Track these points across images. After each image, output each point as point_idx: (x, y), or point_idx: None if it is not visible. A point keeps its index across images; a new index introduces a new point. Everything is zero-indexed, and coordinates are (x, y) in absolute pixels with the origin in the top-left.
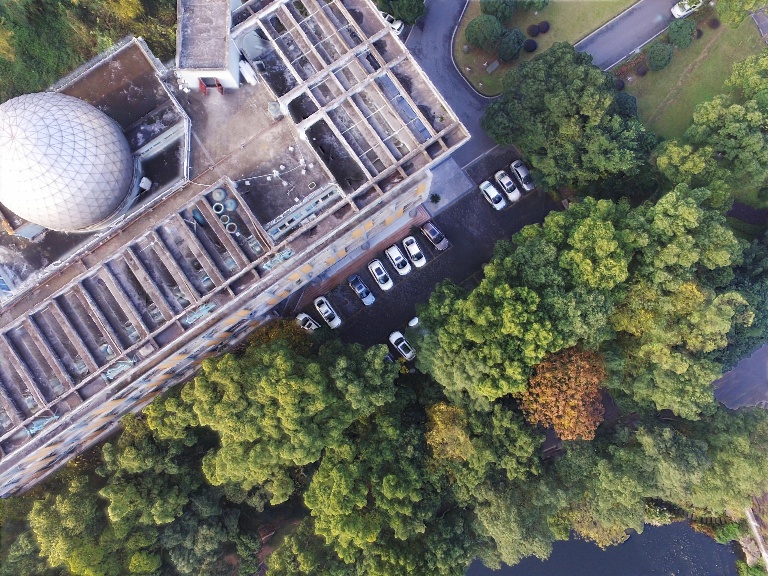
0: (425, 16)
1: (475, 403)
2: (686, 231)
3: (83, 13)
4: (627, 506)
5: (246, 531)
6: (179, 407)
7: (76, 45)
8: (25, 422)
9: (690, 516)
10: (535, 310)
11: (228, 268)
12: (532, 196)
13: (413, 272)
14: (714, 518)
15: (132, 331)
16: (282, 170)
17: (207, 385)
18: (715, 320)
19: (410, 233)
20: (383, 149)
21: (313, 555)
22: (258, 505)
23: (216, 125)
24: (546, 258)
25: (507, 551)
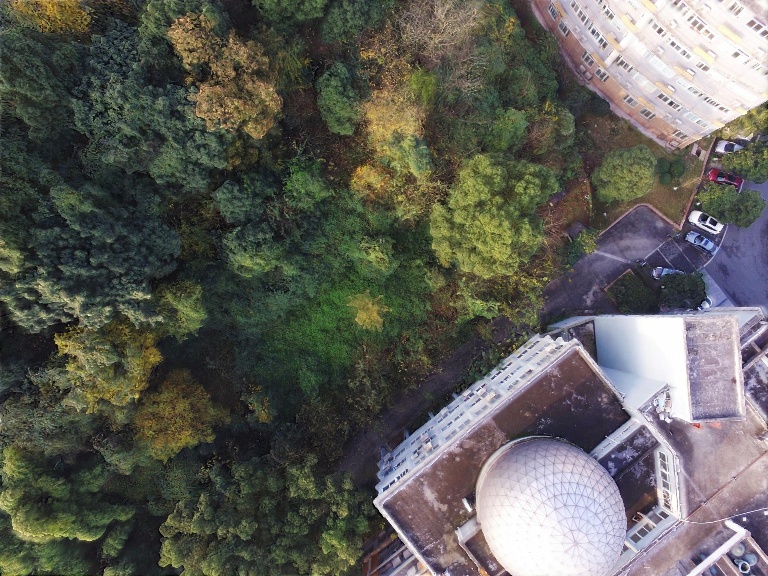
0: None
1: None
2: None
3: (448, 272)
4: None
5: None
6: None
7: (420, 292)
8: None
9: None
10: None
11: None
12: None
13: None
14: None
15: None
16: None
17: None
18: None
19: None
20: None
21: None
22: None
23: (703, 456)
24: None
25: None
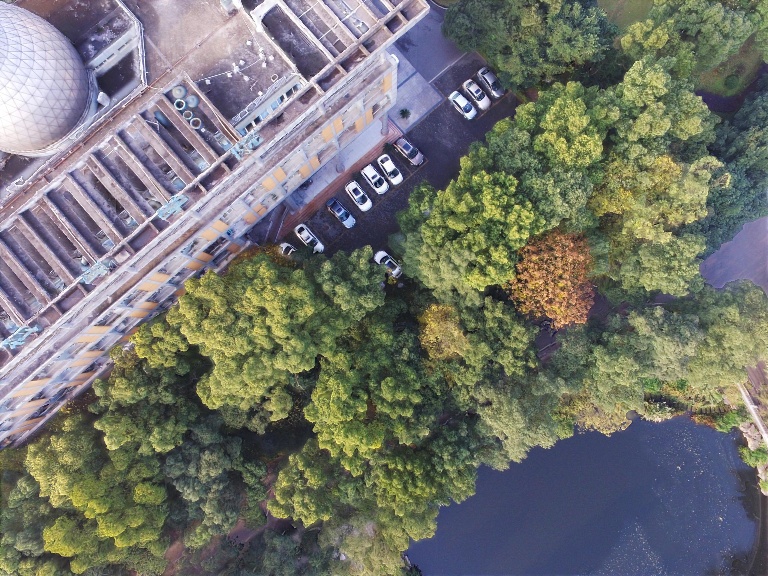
0: None
1: (465, 299)
2: (656, 99)
3: None
4: (626, 385)
5: (250, 460)
6: (166, 332)
7: None
8: (4, 342)
9: (690, 408)
10: (515, 194)
11: (197, 166)
12: (502, 103)
13: (391, 191)
14: (713, 408)
15: (105, 239)
16: (242, 65)
17: (191, 302)
18: (693, 185)
19: (384, 151)
20: (342, 29)
21: (319, 469)
22: (259, 428)
23: (169, 27)
24: (520, 144)
25: (512, 444)
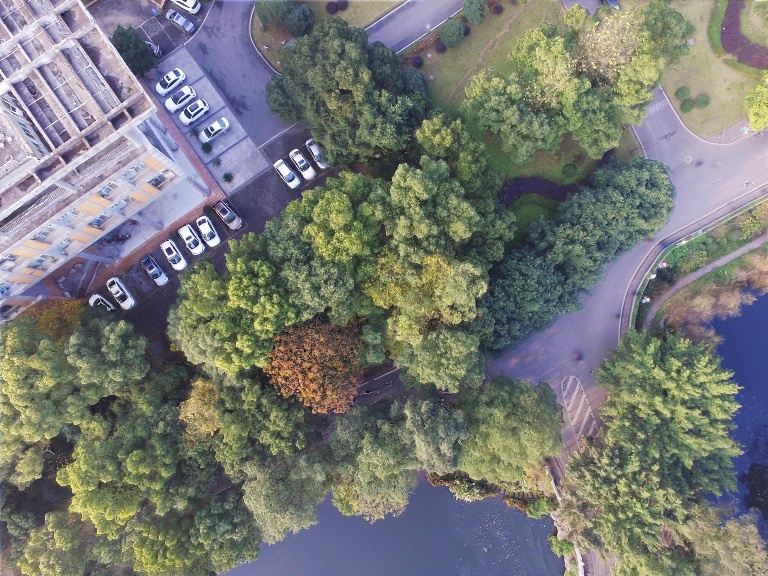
0: None
1: None
2: (419, 203)
3: None
4: None
5: (20, 511)
6: None
7: None
8: None
9: (503, 491)
10: (270, 283)
11: None
12: (328, 174)
13: (208, 252)
14: (526, 493)
15: None
16: None
17: None
18: (448, 291)
19: (204, 213)
20: (69, 120)
21: (69, 532)
22: (19, 484)
23: None
24: (290, 232)
25: (267, 525)
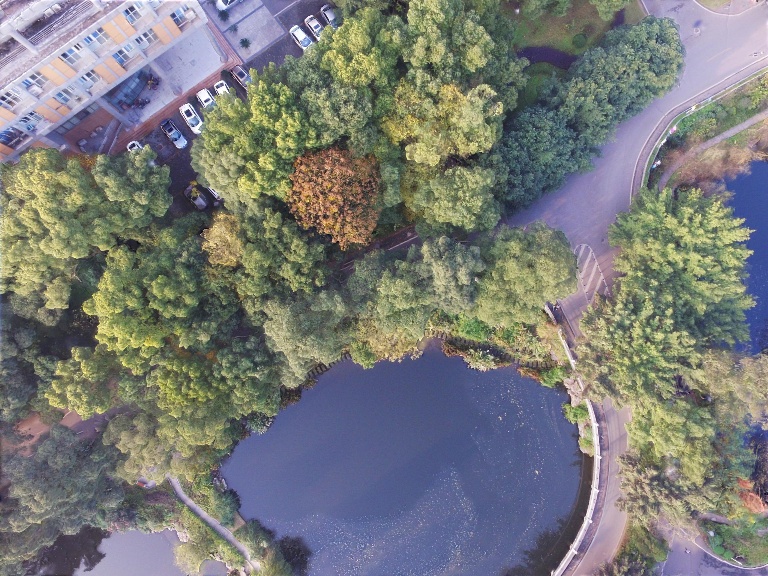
0: None
1: None
2: (435, 25)
3: None
4: (401, 308)
5: (46, 355)
6: None
7: None
8: None
9: (516, 361)
10: None
11: None
12: None
13: None
14: (540, 362)
15: None
16: None
17: None
18: (465, 111)
19: (221, 78)
20: None
21: (95, 362)
22: (46, 319)
23: None
24: (309, 62)
25: (288, 357)
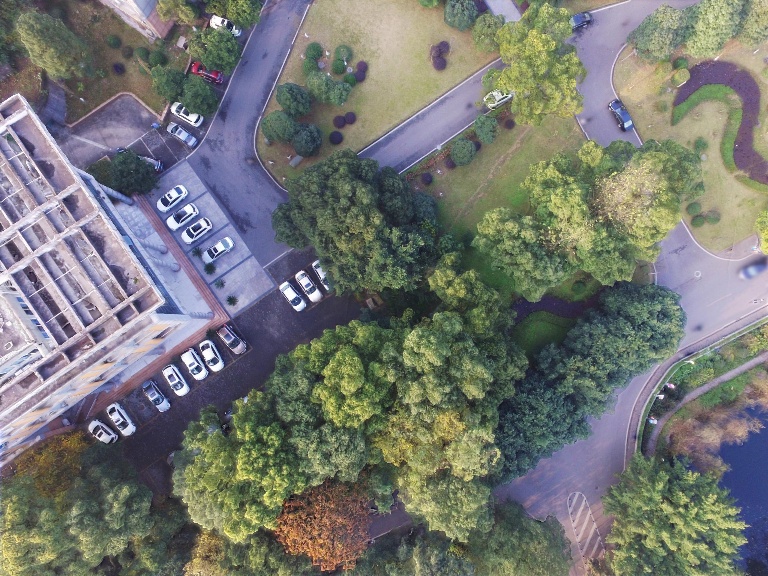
0: (228, 106)
1: None
2: (432, 368)
3: None
4: None
5: None
6: None
7: None
8: None
9: None
10: (279, 450)
11: None
12: None
13: (212, 376)
14: None
15: None
16: None
17: None
18: None
19: (207, 337)
20: None
21: None
22: None
23: None
24: (299, 391)
25: None
